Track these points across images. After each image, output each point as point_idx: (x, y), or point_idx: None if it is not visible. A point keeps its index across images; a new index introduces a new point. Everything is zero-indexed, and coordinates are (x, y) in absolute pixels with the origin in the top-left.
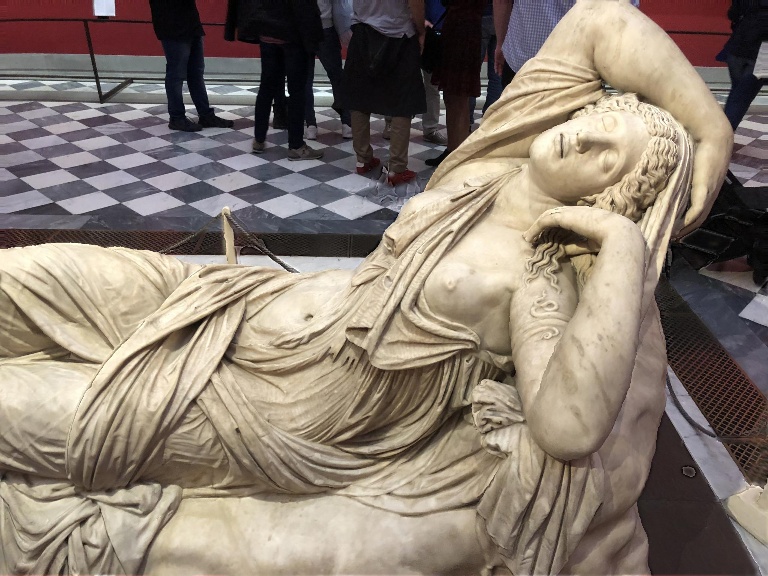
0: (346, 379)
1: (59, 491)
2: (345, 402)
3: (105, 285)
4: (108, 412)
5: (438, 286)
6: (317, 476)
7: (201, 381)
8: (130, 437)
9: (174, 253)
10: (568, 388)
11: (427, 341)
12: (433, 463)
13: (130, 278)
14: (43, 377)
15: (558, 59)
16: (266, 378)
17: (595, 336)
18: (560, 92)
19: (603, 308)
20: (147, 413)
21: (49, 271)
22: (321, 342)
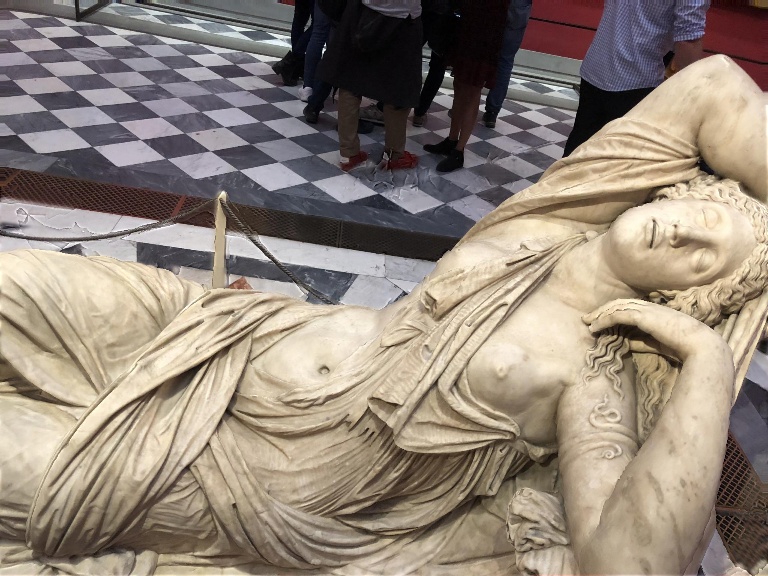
0: (361, 451)
1: (14, 555)
2: (356, 476)
3: (92, 311)
4: (85, 479)
5: (486, 370)
6: (314, 555)
7: (198, 444)
8: (108, 507)
9: (149, 217)
10: (640, 538)
11: (462, 427)
12: (443, 550)
13: (122, 303)
14: (8, 424)
15: (658, 127)
16: (269, 439)
17: (678, 481)
18: (652, 164)
19: (689, 447)
20: (132, 482)
21: (27, 292)
22: (338, 405)
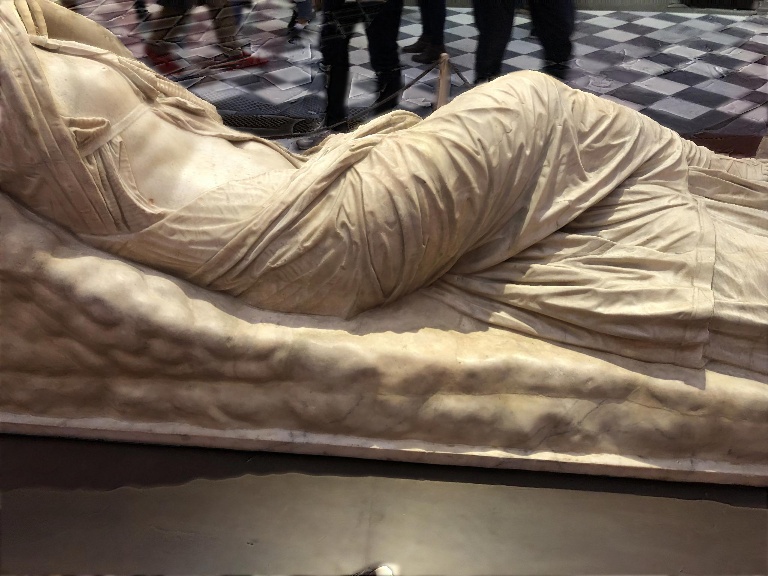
0: None
1: None
2: None
3: None
4: None
5: None
6: None
7: None
8: None
9: None
10: None
11: None
12: None
13: None
14: None
15: None
16: None
17: None
18: None
19: None
20: None
21: None
22: None
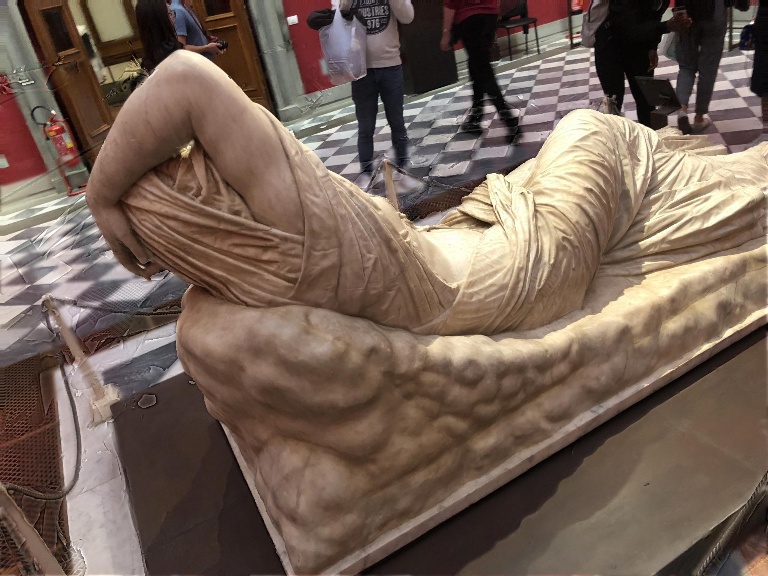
0: None
1: None
2: None
3: None
4: None
5: None
6: None
7: None
8: None
9: None
10: None
11: None
12: None
13: None
14: (522, 170)
15: None
16: None
17: None
18: None
19: None
20: None
21: None
22: None
